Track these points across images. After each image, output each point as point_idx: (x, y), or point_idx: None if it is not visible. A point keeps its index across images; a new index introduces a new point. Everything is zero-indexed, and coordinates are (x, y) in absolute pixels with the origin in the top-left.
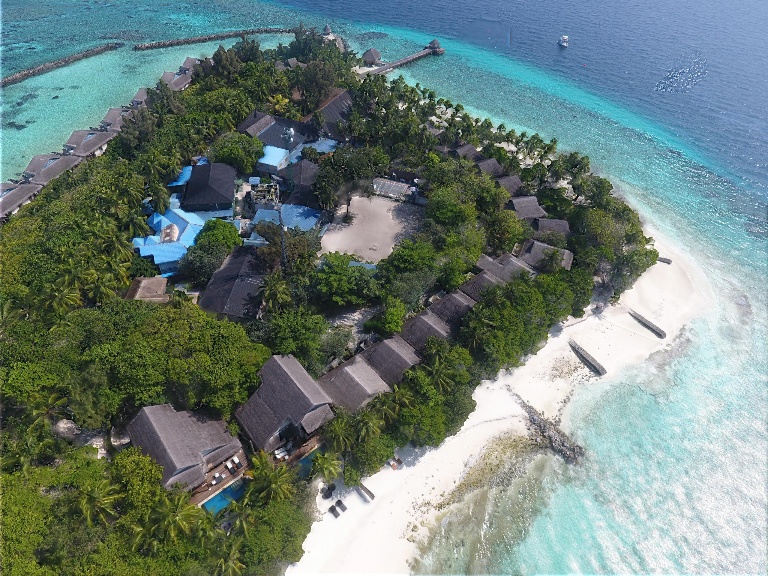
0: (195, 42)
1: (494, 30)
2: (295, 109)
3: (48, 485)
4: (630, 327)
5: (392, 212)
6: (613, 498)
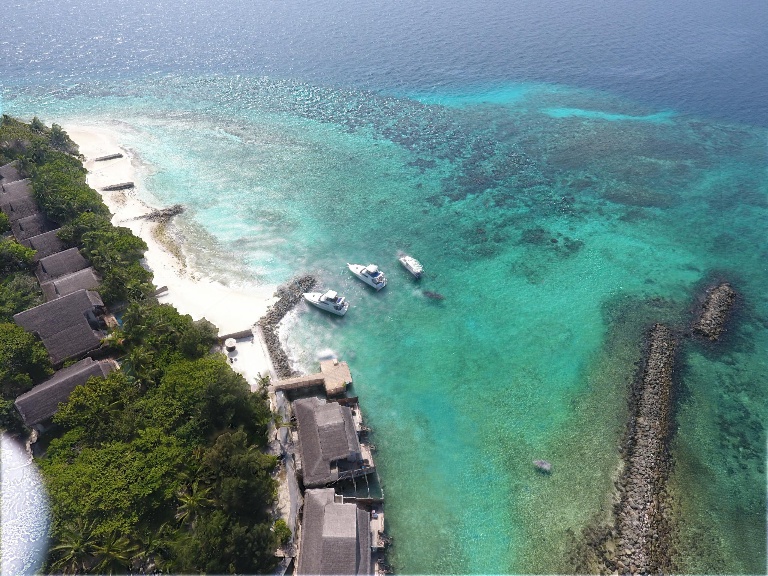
0: None
1: None
2: None
3: (64, 463)
4: (106, 165)
5: None
6: (208, 203)
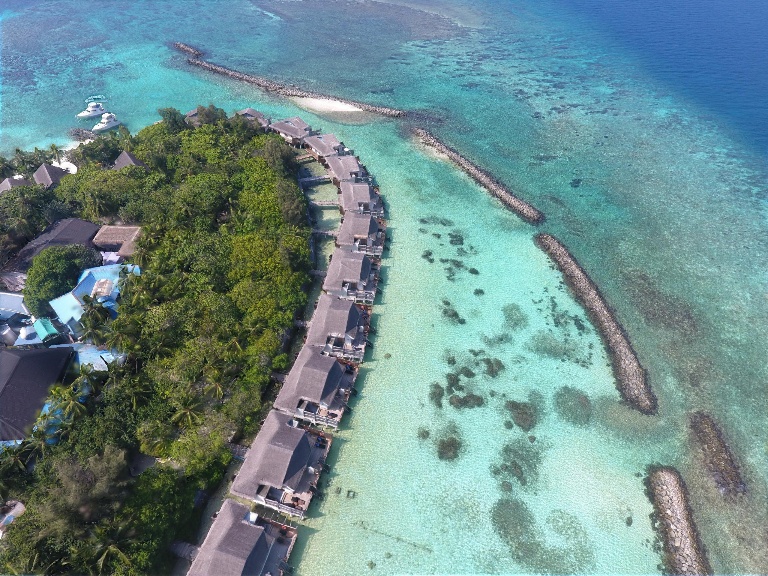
0: None
1: None
2: None
3: None
4: None
5: None
6: None
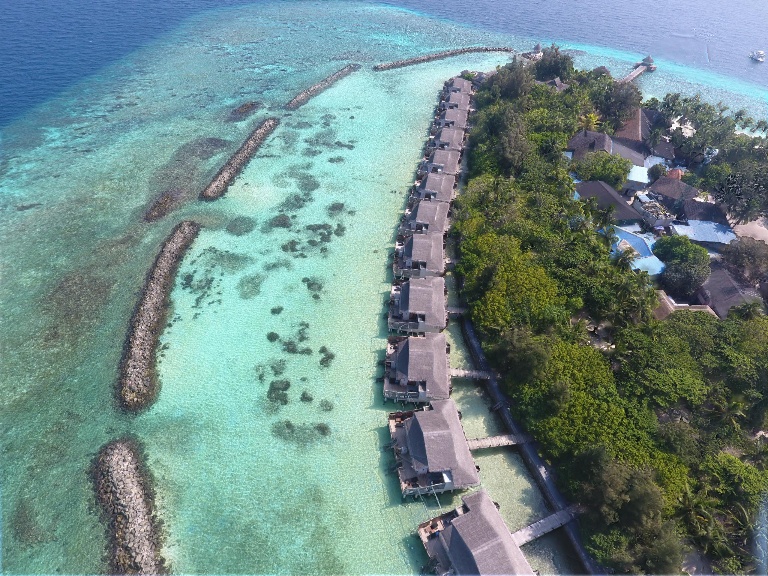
0: (421, 62)
1: (689, 46)
2: (608, 128)
3: None
4: None
5: (765, 226)
6: None
